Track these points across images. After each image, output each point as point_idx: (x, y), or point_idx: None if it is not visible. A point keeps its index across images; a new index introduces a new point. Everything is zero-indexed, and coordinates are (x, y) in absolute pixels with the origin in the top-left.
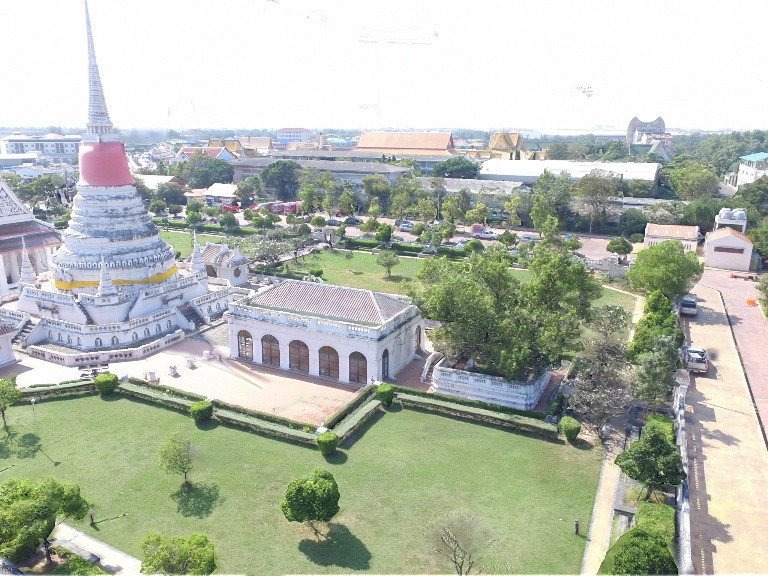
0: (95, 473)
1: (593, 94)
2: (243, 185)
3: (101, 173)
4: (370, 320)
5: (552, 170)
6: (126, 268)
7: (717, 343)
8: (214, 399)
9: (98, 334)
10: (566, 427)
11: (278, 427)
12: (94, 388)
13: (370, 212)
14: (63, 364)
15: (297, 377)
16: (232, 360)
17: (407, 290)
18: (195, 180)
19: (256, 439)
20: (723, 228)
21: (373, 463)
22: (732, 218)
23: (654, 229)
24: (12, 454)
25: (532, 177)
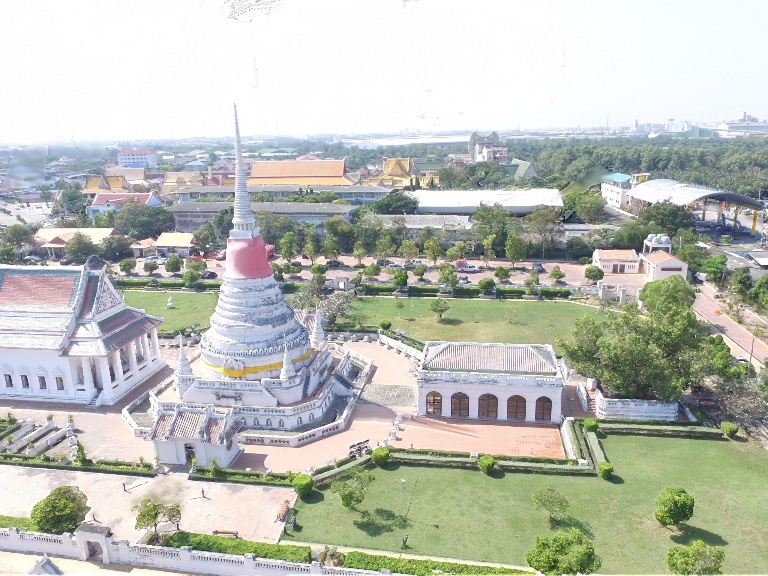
0: (476, 526)
1: (614, 170)
2: (202, 234)
3: (255, 266)
4: (543, 370)
5: (487, 203)
6: (290, 349)
7: (733, 349)
8: (478, 453)
9: (300, 414)
10: (731, 429)
11: (556, 465)
12: (365, 462)
13: (355, 255)
14: (288, 446)
15: (491, 423)
16: (422, 417)
17: (560, 343)
18: (136, 230)
19: (545, 477)
20: (657, 251)
21: (642, 478)
22: (660, 242)
23: (603, 254)
24: (392, 527)
25: (463, 207)
